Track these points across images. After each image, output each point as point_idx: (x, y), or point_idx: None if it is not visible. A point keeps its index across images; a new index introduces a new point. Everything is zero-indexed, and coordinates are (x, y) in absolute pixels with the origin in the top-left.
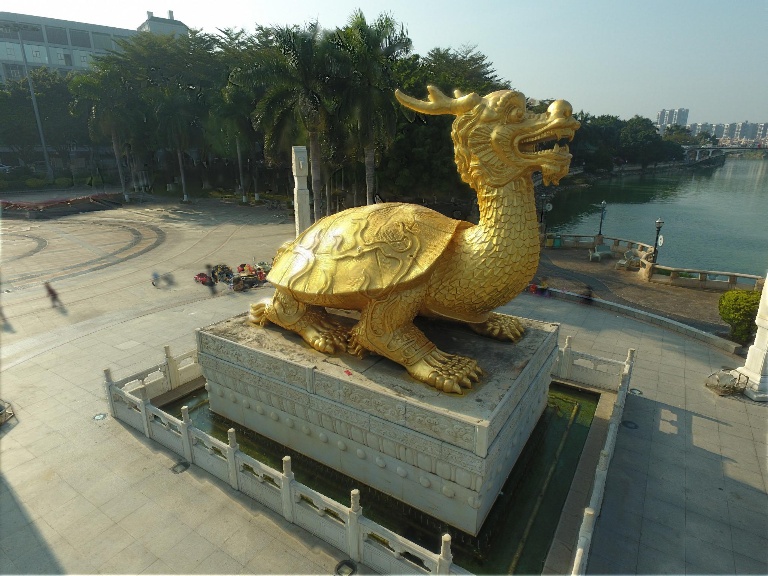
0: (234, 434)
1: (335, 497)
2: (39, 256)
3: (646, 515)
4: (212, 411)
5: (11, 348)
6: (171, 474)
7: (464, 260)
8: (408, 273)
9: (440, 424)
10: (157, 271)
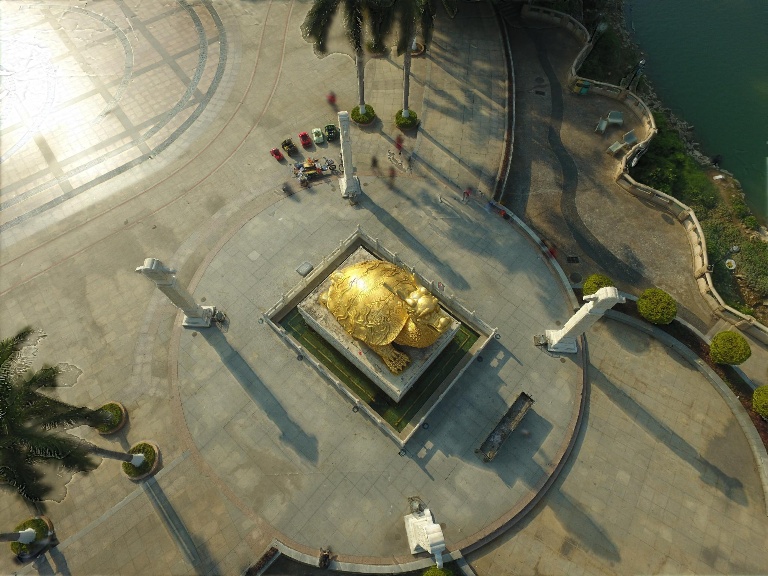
0: None
1: (355, 375)
2: (138, 81)
3: (456, 404)
4: (306, 323)
5: (191, 242)
6: (297, 361)
7: (406, 336)
8: (382, 342)
9: (387, 385)
10: (240, 129)
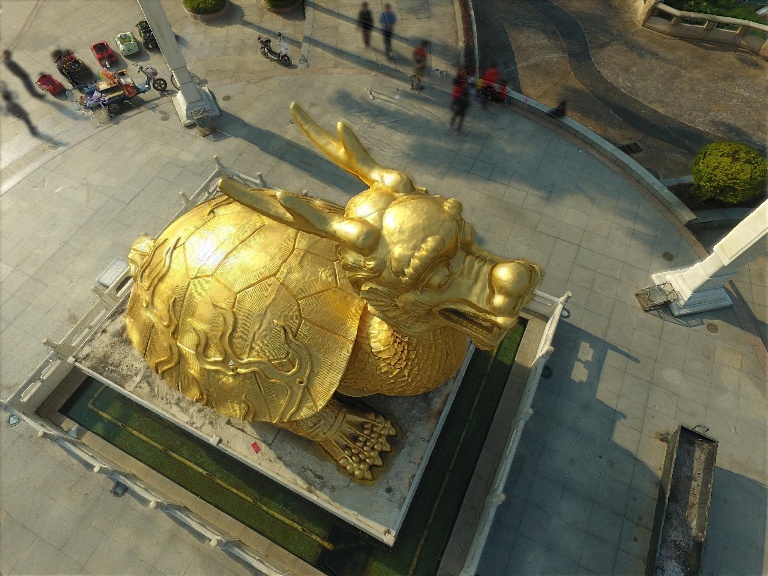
0: (157, 505)
1: (271, 491)
2: None
3: (530, 499)
4: None
5: None
6: (114, 499)
7: (370, 372)
8: (299, 408)
9: None
10: None
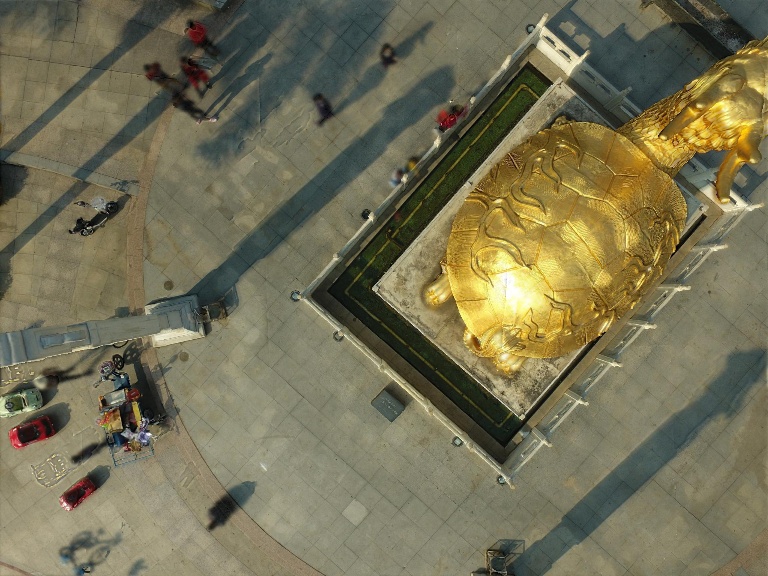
0: None
1: None
2: None
3: None
4: None
5: None
6: None
7: None
8: None
9: None
10: None
